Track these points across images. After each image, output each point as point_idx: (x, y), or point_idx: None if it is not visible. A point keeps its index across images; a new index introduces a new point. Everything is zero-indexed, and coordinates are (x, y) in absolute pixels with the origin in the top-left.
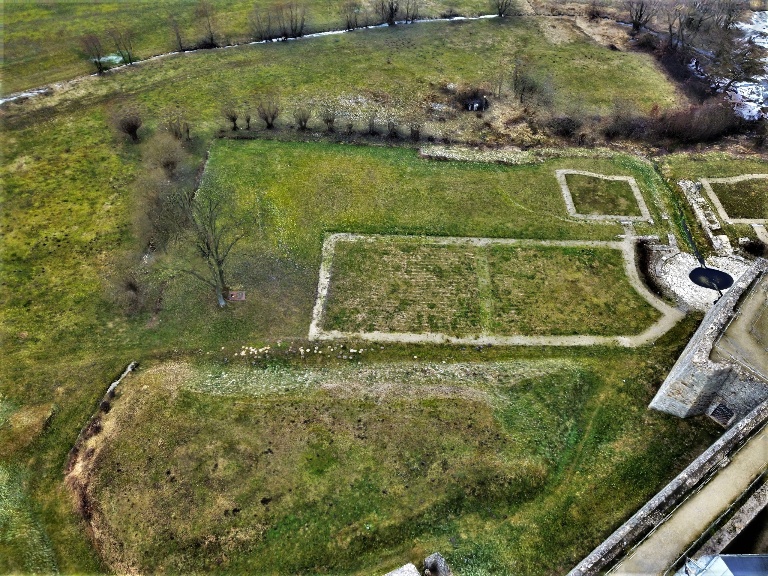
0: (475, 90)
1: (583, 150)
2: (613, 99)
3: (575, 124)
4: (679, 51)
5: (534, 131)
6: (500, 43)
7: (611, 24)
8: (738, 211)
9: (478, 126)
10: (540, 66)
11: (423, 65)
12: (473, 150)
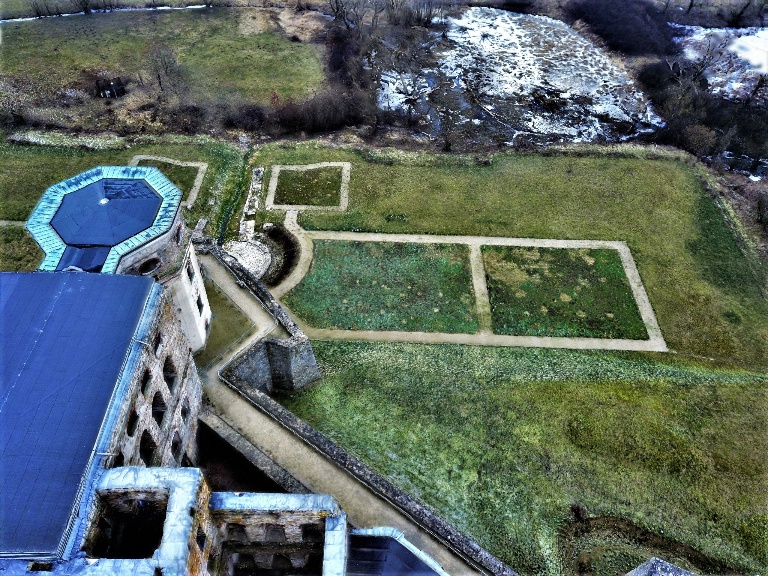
0: (117, 77)
1: (180, 137)
2: (253, 88)
3: (199, 112)
4: (359, 43)
5: (153, 118)
6: (187, 33)
7: (313, 16)
8: (287, 197)
9: (99, 112)
10: (205, 55)
11: (90, 53)
12: (67, 135)
